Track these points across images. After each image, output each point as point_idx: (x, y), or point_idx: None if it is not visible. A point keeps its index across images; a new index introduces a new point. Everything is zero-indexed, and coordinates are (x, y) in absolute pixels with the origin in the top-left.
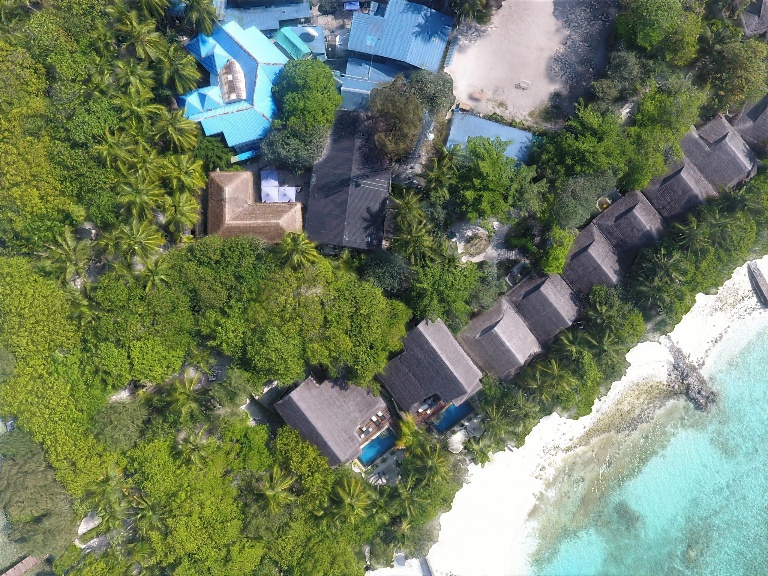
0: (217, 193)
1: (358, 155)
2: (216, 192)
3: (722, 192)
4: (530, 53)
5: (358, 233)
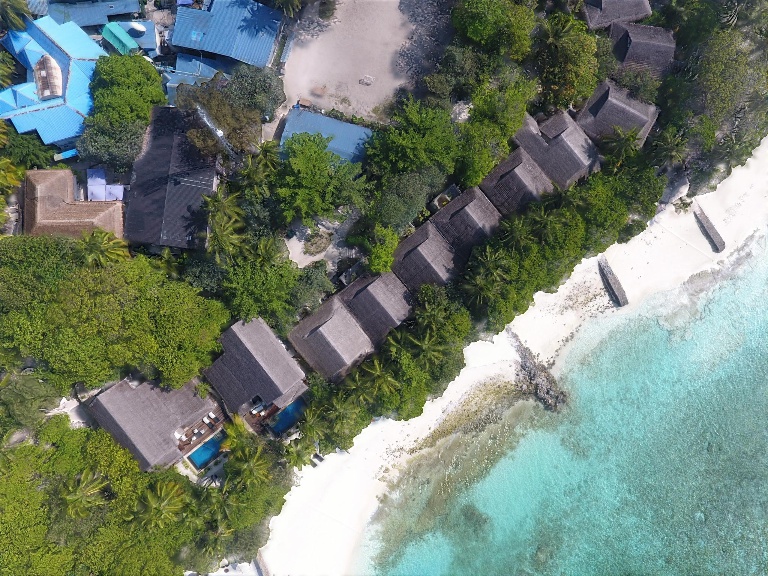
0: (31, 192)
1: (177, 152)
2: (30, 191)
3: (554, 188)
4: (375, 48)
5: (178, 232)
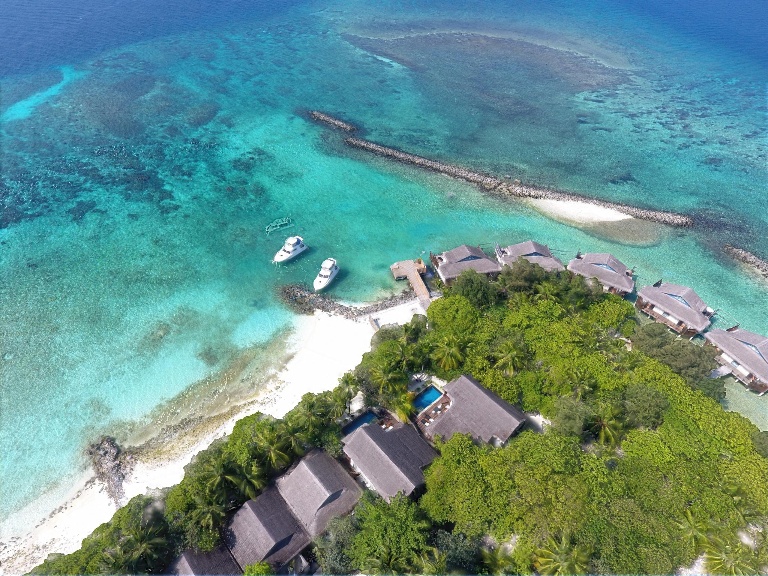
0: None
1: None
2: None
3: None
4: None
5: None
